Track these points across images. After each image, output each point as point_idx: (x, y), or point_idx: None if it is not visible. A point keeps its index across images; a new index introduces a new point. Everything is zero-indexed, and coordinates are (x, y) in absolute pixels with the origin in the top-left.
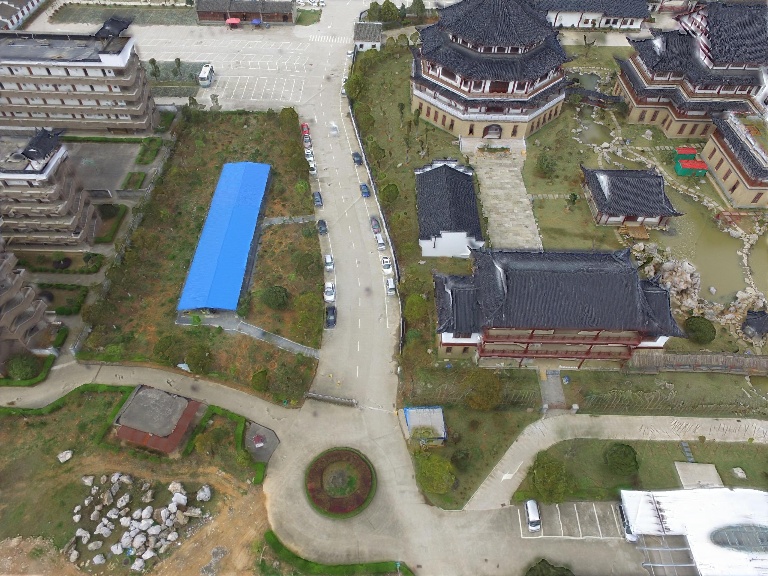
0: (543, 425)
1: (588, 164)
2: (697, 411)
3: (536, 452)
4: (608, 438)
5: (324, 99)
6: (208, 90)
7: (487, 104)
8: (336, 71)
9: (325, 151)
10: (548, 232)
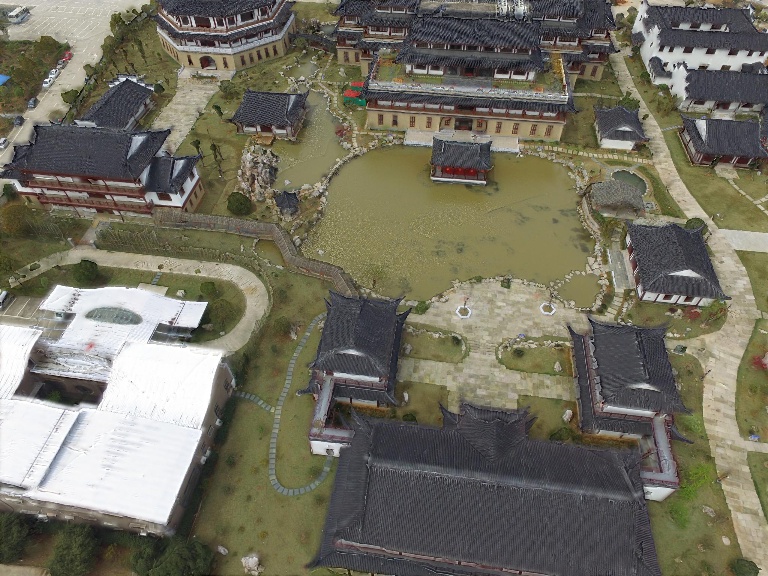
0: (66, 254)
1: (274, 91)
2: (184, 253)
3: (45, 268)
4: (106, 265)
5: (104, 36)
6: (17, 26)
7: (193, 37)
8: (132, 17)
9: (71, 72)
10: (194, 136)
